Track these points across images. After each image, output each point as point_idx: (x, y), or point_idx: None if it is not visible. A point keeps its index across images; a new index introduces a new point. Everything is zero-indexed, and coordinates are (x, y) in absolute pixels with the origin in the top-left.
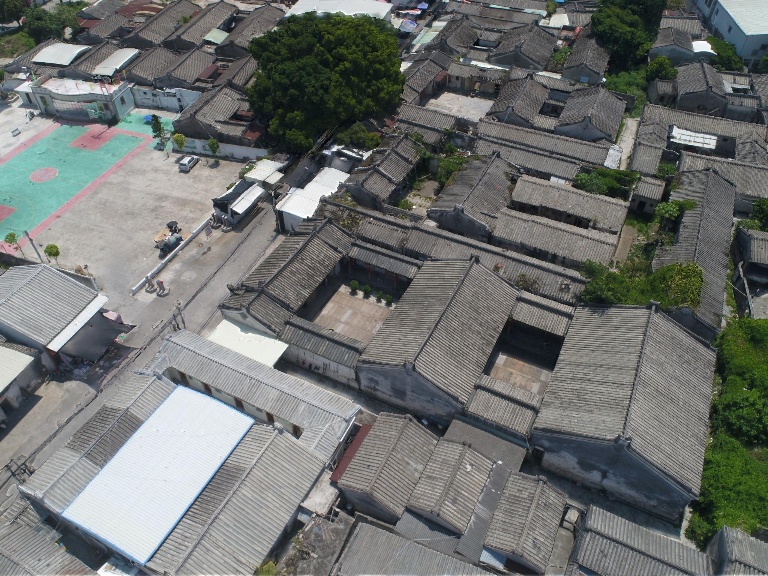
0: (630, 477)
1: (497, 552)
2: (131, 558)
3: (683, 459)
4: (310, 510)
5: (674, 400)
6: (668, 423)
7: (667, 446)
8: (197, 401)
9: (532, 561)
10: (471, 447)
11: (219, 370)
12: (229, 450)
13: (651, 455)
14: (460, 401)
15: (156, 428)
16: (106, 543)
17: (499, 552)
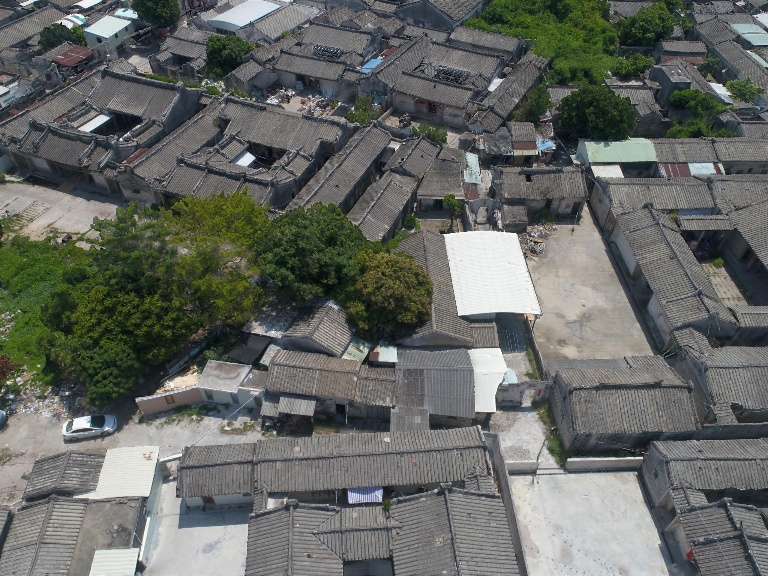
0: (432, 21)
1: (374, 33)
2: (237, 26)
3: (453, 13)
4: (303, 26)
5: (456, 1)
6: (450, 4)
7: (447, 8)
8: (257, 1)
9: (385, 30)
10: (369, 11)
11: (265, 0)
12: (271, 11)
13: (438, 7)
14: (368, 4)
15: (241, 6)
16: (226, 24)
17: (374, 32)
